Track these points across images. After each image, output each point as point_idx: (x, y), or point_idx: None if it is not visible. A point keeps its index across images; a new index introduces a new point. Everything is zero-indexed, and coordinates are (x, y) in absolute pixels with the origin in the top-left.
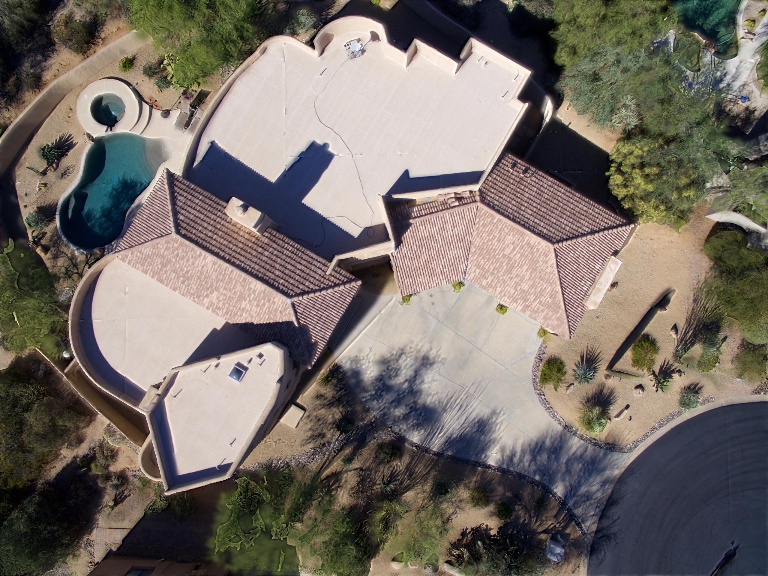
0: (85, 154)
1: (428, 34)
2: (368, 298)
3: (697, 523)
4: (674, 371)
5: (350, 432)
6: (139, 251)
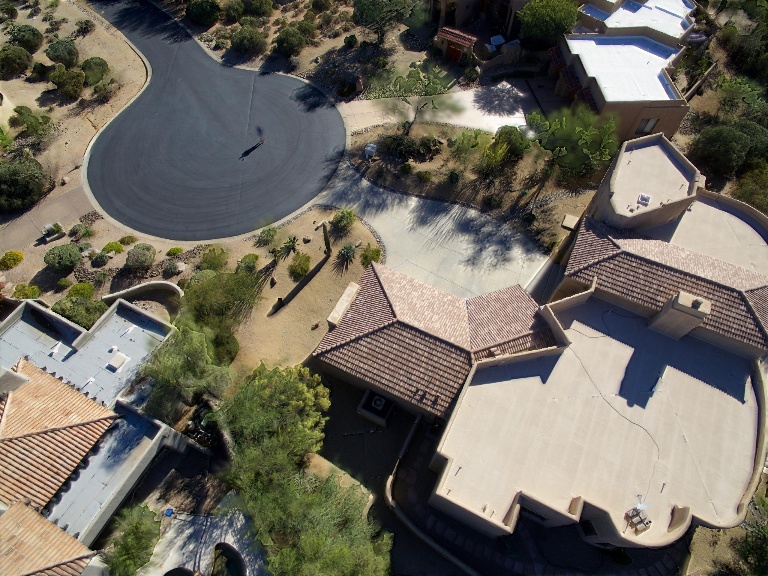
0: None
1: None
2: None
3: (268, 169)
4: (279, 252)
5: (524, 215)
6: (764, 283)
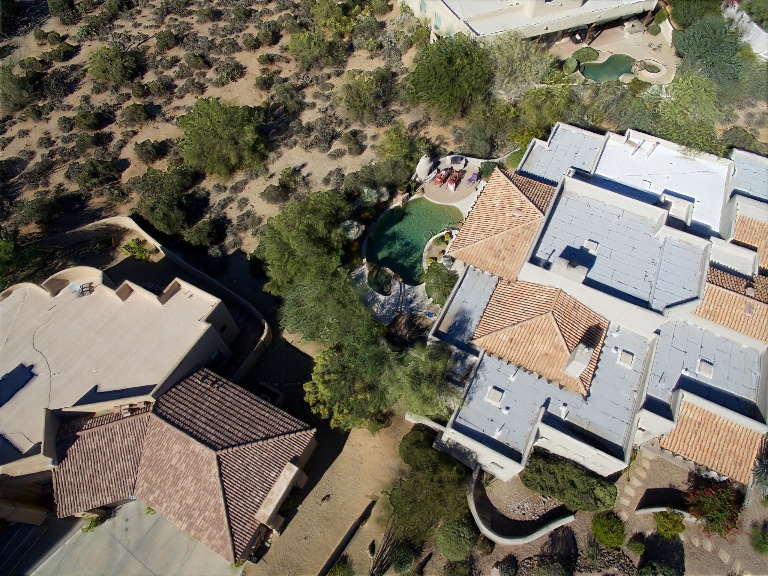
0: None
1: (183, 278)
2: (56, 526)
3: None
4: None
5: None
6: None
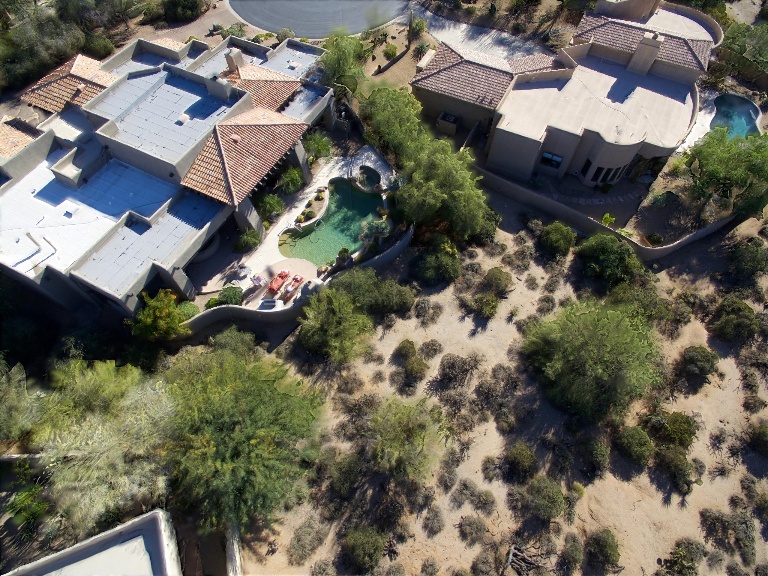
0: (762, 134)
1: None
2: None
3: (359, 3)
4: None
5: None
6: None
